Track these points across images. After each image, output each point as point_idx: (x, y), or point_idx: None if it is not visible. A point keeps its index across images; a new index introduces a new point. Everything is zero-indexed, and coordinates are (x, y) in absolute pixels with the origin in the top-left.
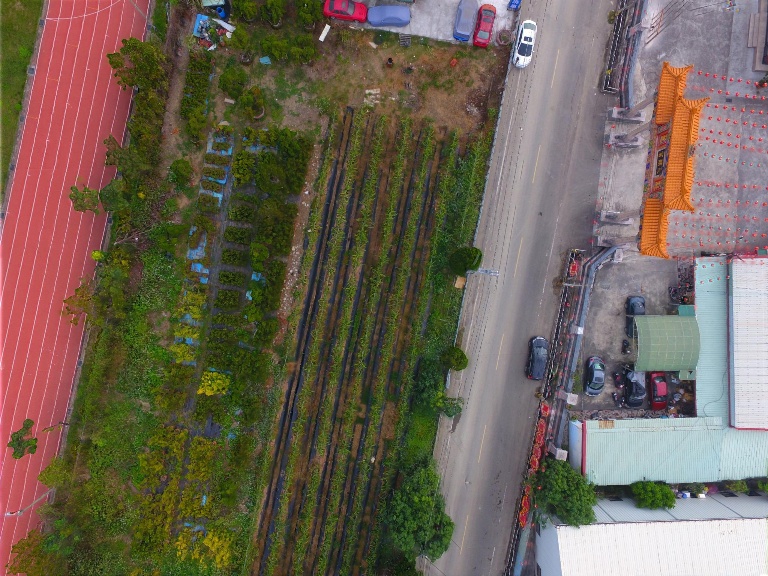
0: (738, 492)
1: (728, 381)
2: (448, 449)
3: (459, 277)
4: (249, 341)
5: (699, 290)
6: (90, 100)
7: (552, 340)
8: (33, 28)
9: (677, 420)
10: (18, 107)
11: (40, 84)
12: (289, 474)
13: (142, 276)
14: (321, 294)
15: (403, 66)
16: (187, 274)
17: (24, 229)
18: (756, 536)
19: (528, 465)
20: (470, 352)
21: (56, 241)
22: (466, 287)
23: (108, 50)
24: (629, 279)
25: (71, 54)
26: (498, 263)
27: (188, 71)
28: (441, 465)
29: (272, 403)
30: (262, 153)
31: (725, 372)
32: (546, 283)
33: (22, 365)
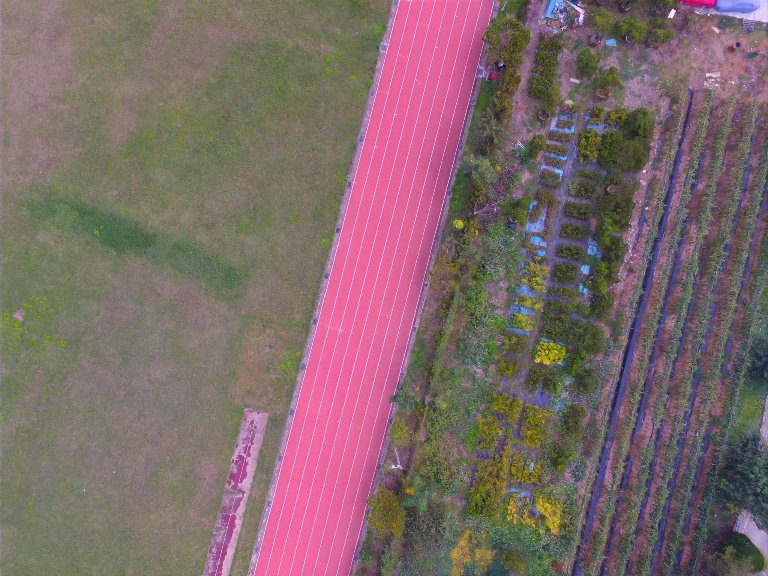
0: None
1: None
2: None
3: None
4: (582, 314)
5: None
6: (437, 77)
7: None
8: (388, 7)
9: None
10: (371, 82)
11: (391, 60)
12: (625, 445)
13: (486, 247)
14: (654, 271)
15: (745, 51)
16: (532, 246)
17: (369, 198)
18: None
19: None
20: None
21: (398, 211)
22: None
23: (456, 30)
24: None
25: (422, 33)
26: None
27: (537, 51)
28: None
29: (604, 375)
30: (611, 131)
31: None
32: None
33: (361, 328)
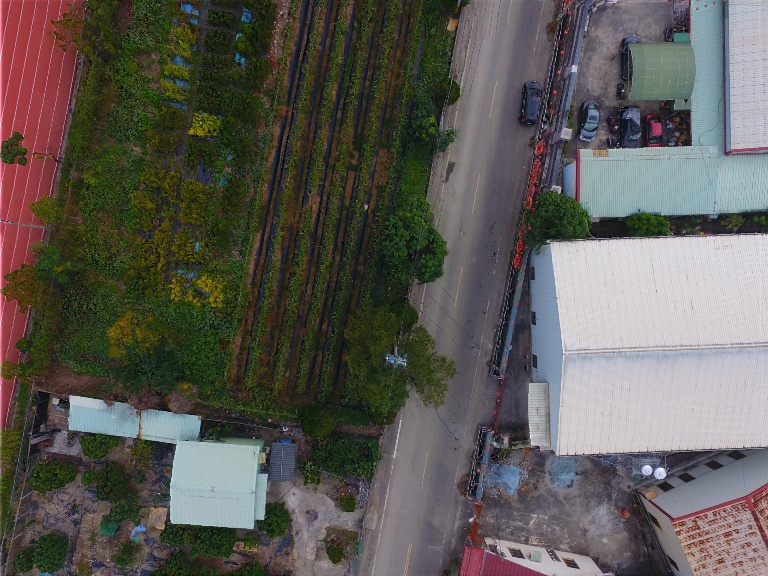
0: (734, 228)
1: (724, 107)
2: (442, 199)
3: (451, 19)
4: (240, 85)
5: (694, 17)
6: None
7: (546, 86)
8: None
9: (672, 149)
10: None
11: None
12: (281, 213)
13: (131, 15)
14: None
15: None
16: (176, 10)
17: None
18: (751, 250)
19: (522, 213)
20: (463, 99)
21: None
22: (458, 27)
23: None
24: (624, 23)
25: None
26: (491, 7)
27: None
28: (435, 213)
29: None
30: None
31: (721, 99)
32: (540, 29)
33: (12, 111)
